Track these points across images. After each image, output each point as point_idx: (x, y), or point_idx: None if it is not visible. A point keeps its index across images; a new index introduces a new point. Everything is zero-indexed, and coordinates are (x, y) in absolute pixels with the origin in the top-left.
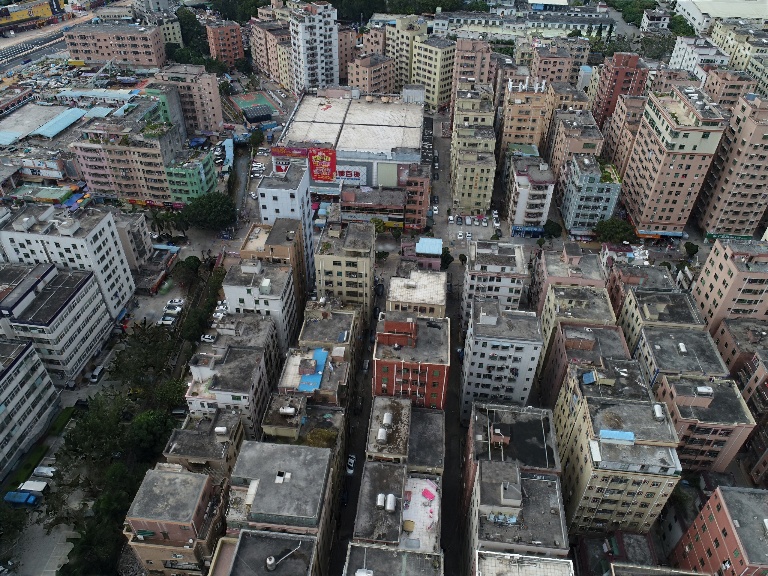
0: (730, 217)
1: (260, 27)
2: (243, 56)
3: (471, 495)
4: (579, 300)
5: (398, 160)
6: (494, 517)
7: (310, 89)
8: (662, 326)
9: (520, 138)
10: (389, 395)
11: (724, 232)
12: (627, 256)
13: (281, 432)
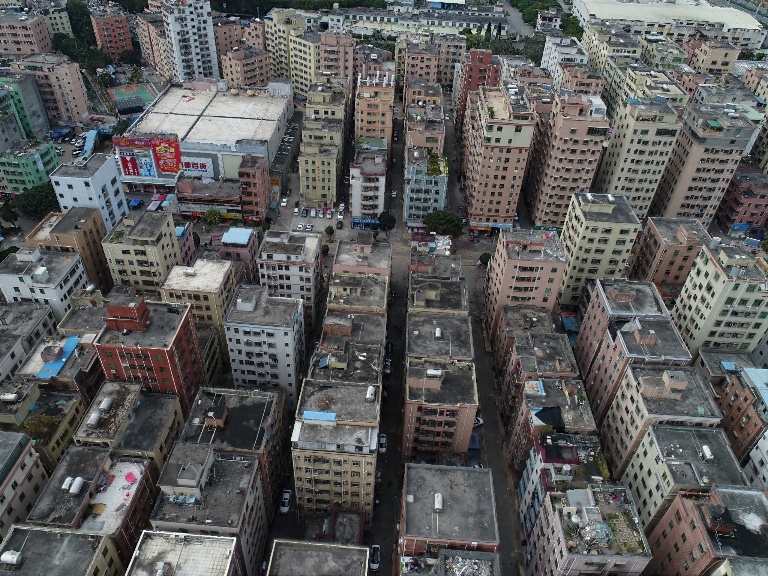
0: (554, 210)
1: (143, 18)
2: (132, 48)
3: None
4: None
5: (242, 152)
6: (174, 497)
7: (176, 81)
8: (429, 312)
9: (372, 132)
10: (122, 381)
11: (550, 224)
12: (428, 246)
13: (2, 419)
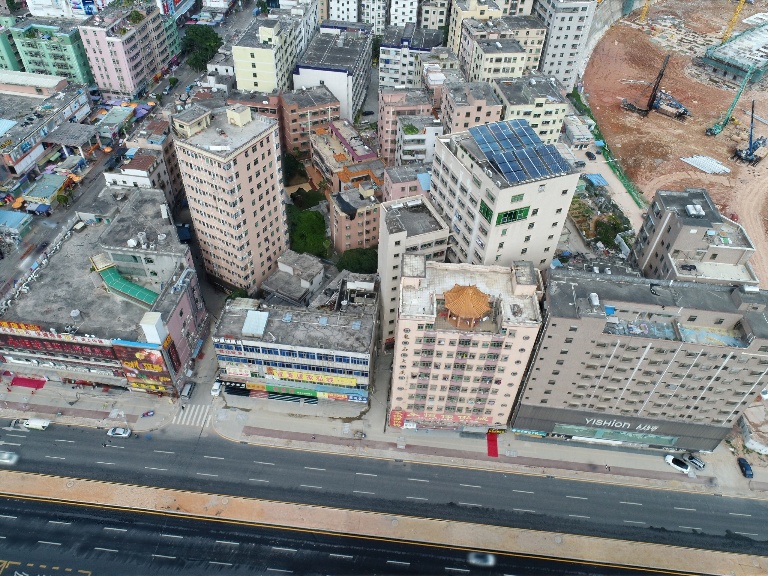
0: None
1: None
2: None
3: None
4: None
5: None
6: None
7: None
8: None
9: None
10: None
11: None
12: None
13: None
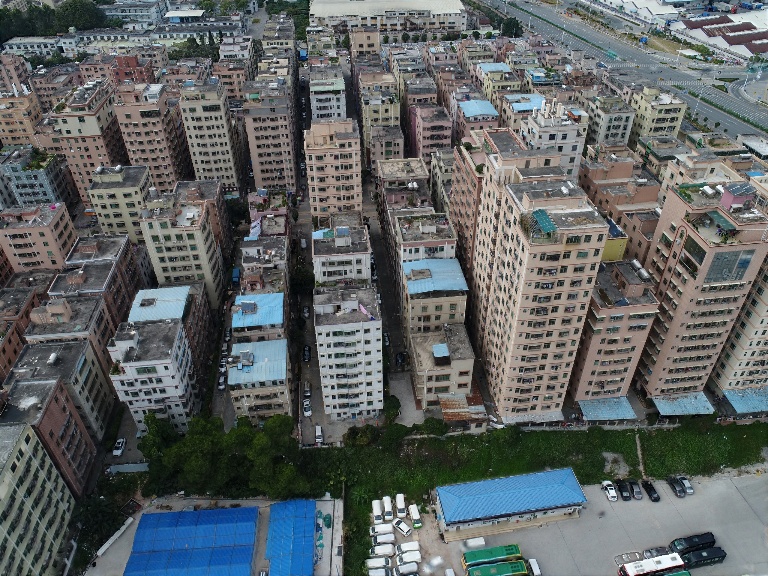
0: None
1: None
2: None
3: None
4: None
5: None
6: None
7: None
8: None
9: (17, 140)
10: None
11: None
12: None
13: None
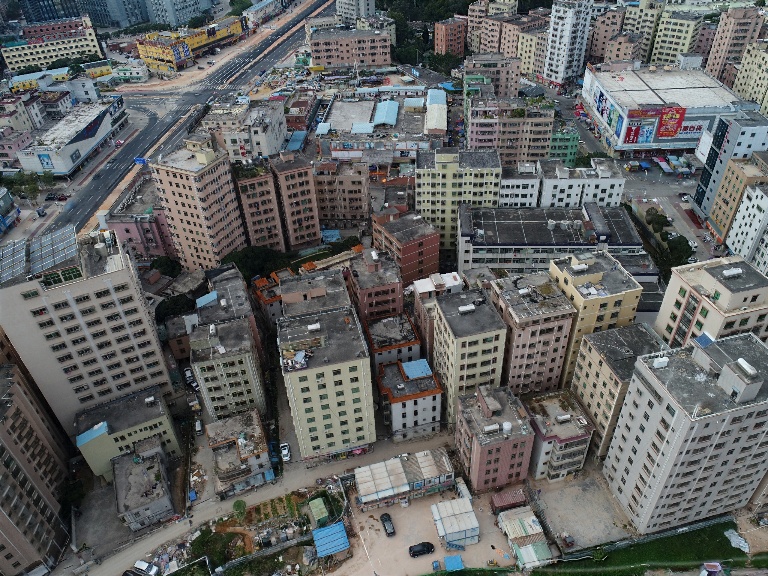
0: None
1: (492, 20)
2: (463, 49)
3: None
4: None
5: None
6: None
7: (595, 65)
8: None
9: None
10: None
11: None
12: None
13: None
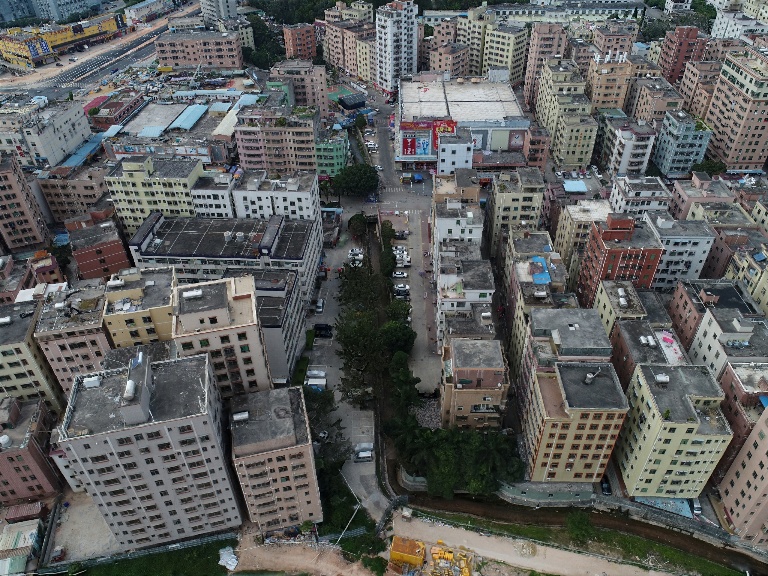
0: None
1: (336, 26)
2: (315, 54)
3: (690, 344)
4: (721, 212)
5: (511, 126)
6: (732, 343)
7: (406, 75)
8: None
9: (606, 103)
10: None
11: None
12: (739, 182)
13: None
